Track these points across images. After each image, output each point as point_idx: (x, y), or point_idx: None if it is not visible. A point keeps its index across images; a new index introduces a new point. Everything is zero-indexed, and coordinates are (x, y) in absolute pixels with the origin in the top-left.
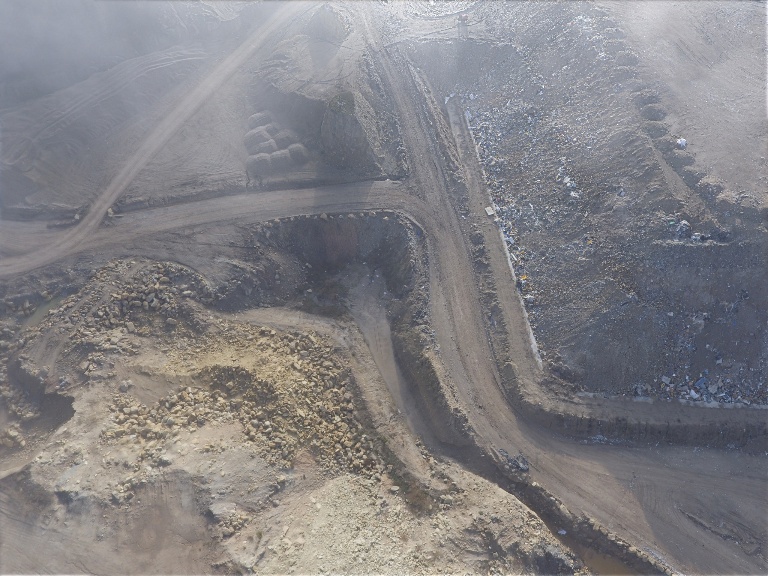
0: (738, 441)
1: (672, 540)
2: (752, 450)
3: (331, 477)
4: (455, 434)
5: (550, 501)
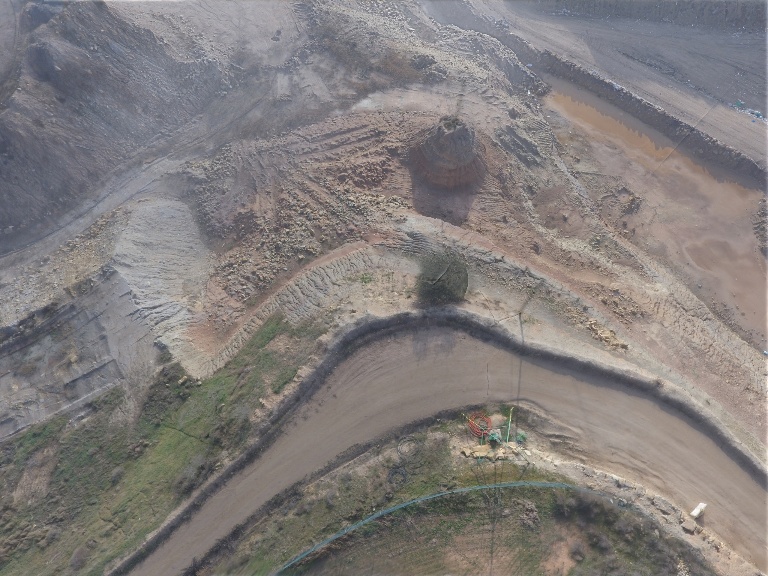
0: (671, 14)
1: (608, 64)
2: (682, 22)
3: (368, 13)
4: (457, 7)
5: (522, 43)
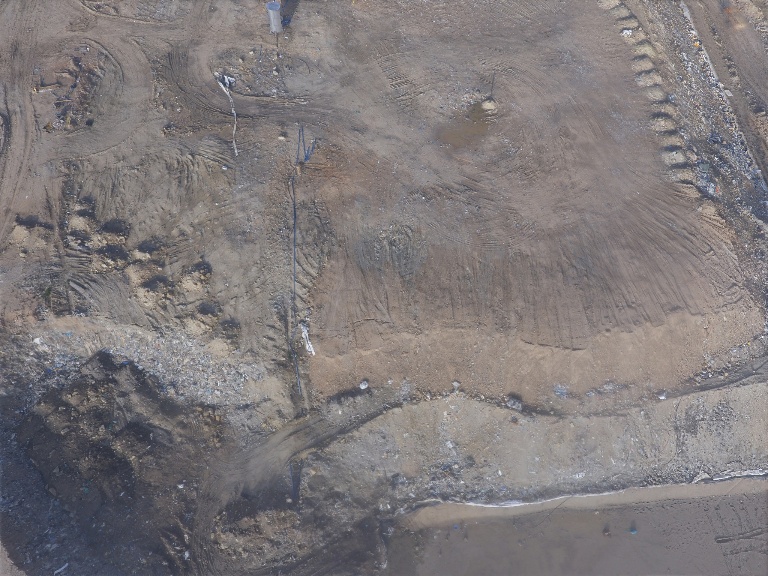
0: None
1: None
2: None
3: None
4: None
5: None
